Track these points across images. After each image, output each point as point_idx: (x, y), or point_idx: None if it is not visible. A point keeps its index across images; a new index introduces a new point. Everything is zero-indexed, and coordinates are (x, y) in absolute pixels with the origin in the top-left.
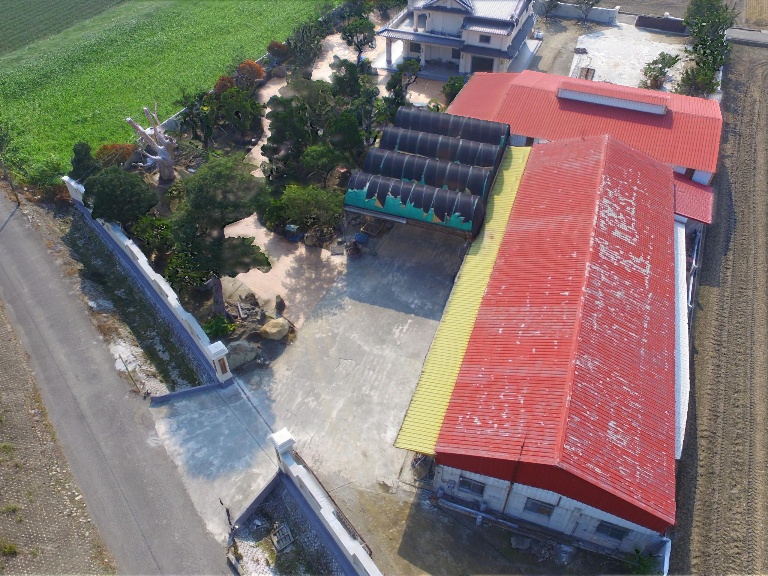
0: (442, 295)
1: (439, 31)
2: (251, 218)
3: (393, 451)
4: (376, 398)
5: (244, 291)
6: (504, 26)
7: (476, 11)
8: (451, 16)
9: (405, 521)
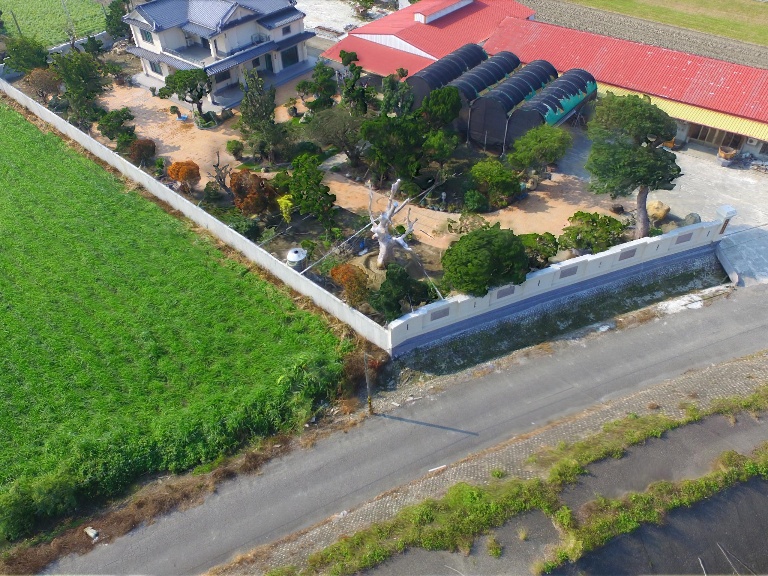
0: None
1: (237, 47)
2: None
3: (765, 181)
4: (719, 181)
5: None
6: (291, 12)
7: (261, 11)
8: (244, 26)
9: None
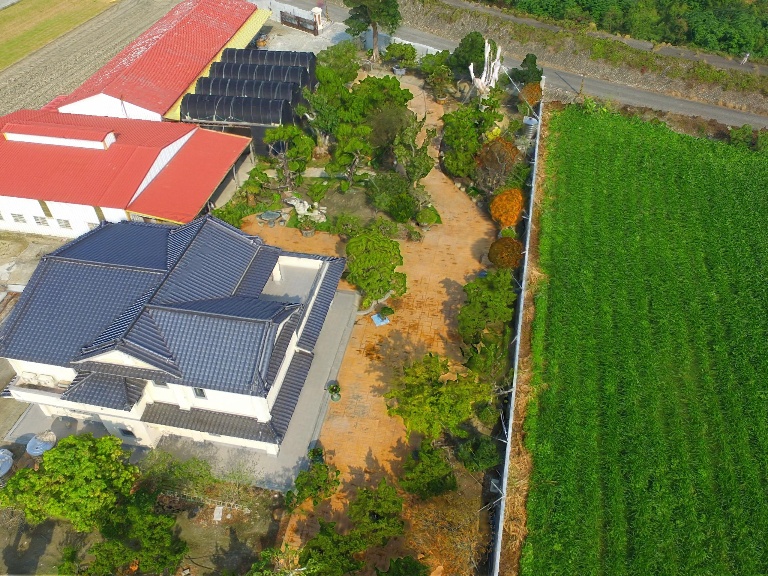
0: None
1: None
2: None
3: None
4: (287, 50)
5: (374, 73)
6: None
7: (167, 232)
8: None
9: None
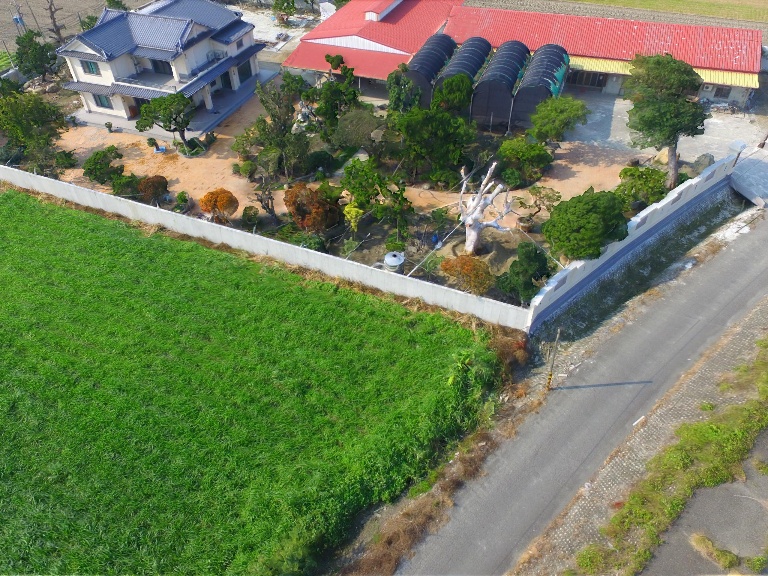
0: (587, 106)
1: (196, 68)
2: (522, 193)
3: (728, 120)
4: None
5: None
6: (239, 25)
7: (212, 26)
8: (200, 44)
9: (767, 116)
